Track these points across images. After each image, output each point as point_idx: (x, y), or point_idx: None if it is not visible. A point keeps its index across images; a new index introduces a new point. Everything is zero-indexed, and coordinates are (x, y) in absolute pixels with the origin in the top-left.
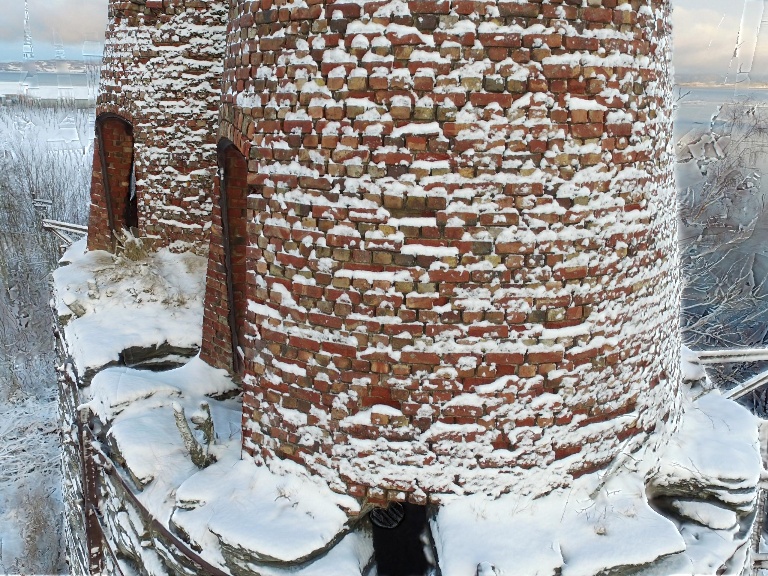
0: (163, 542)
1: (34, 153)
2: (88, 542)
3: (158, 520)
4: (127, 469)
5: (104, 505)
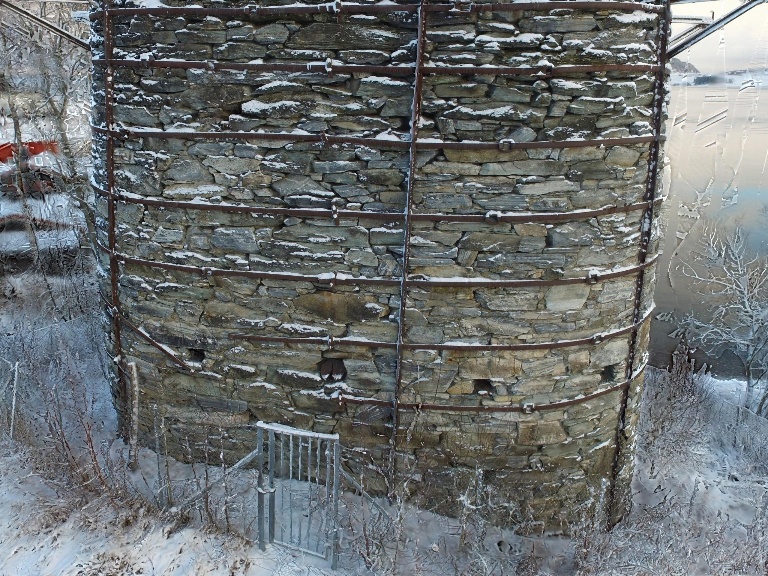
0: (542, 15)
1: None
2: (416, 97)
3: (541, 2)
4: (488, 2)
5: (430, 64)
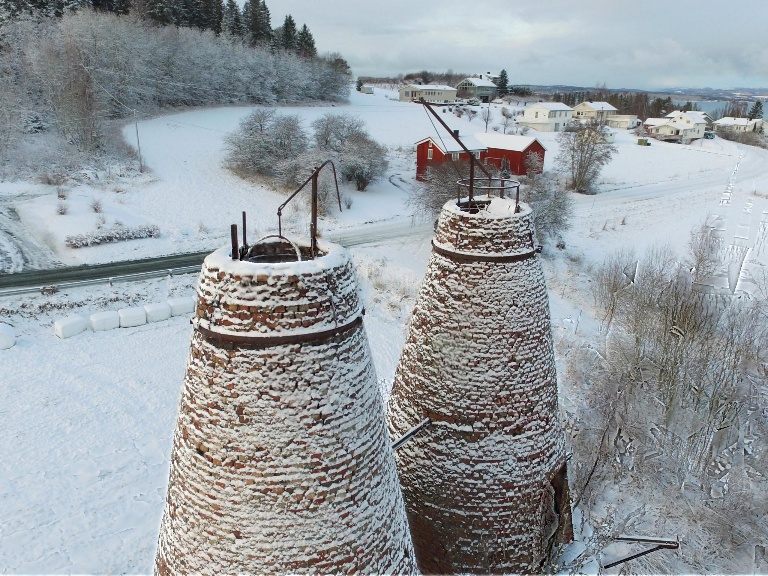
0: None
1: (686, 289)
2: None
3: None
4: None
5: None
